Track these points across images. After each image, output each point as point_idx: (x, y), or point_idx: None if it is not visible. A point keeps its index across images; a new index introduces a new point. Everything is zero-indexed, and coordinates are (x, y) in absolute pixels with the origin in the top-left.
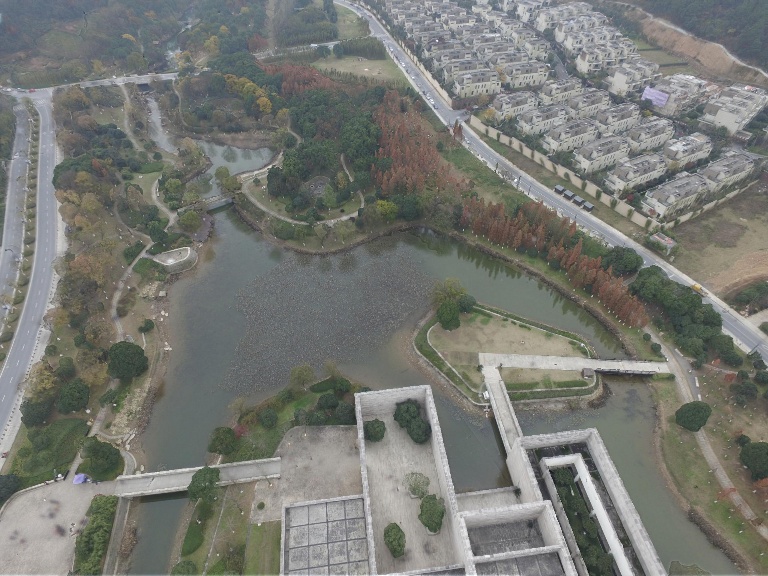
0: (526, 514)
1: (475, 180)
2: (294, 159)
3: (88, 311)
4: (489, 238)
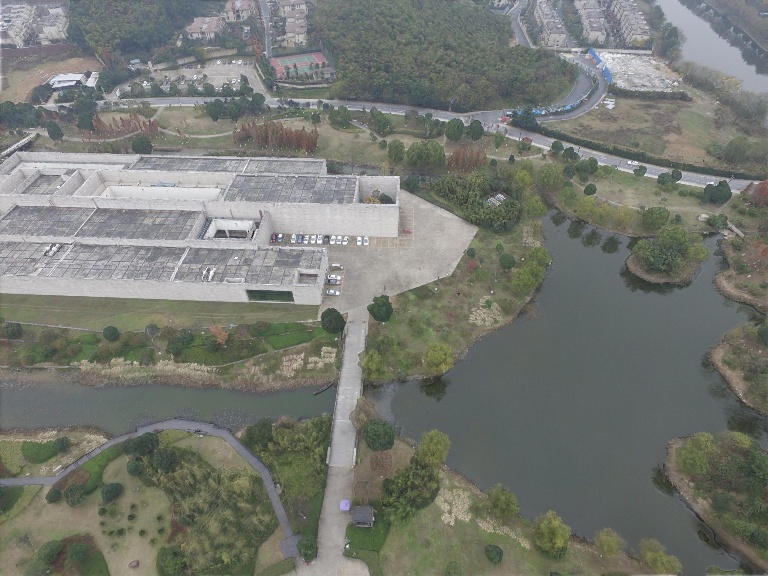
0: (21, 182)
1: None
2: None
3: None
4: None
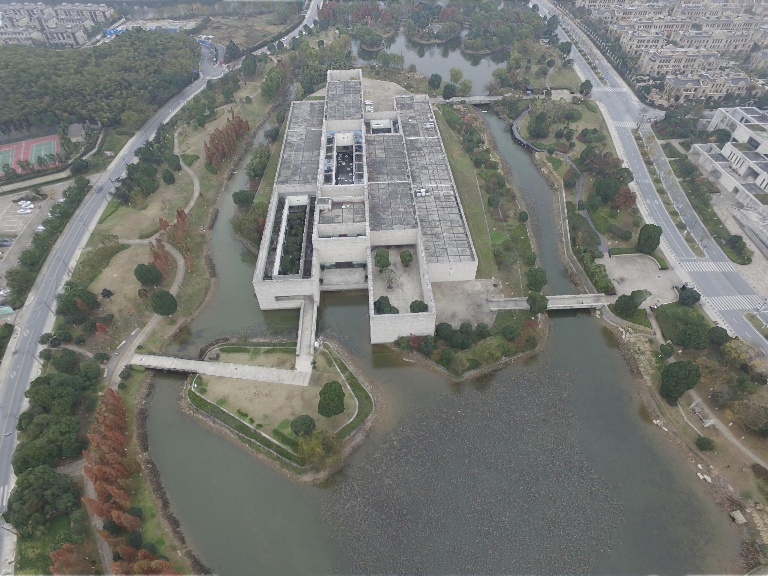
0: None
1: None
2: None
3: None
4: None
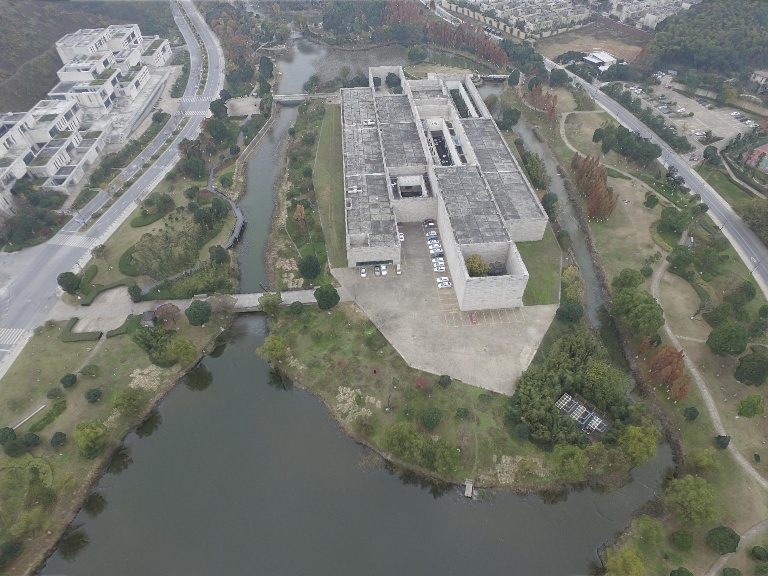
0: None
1: None
2: (338, 8)
3: (243, 57)
4: (441, 42)
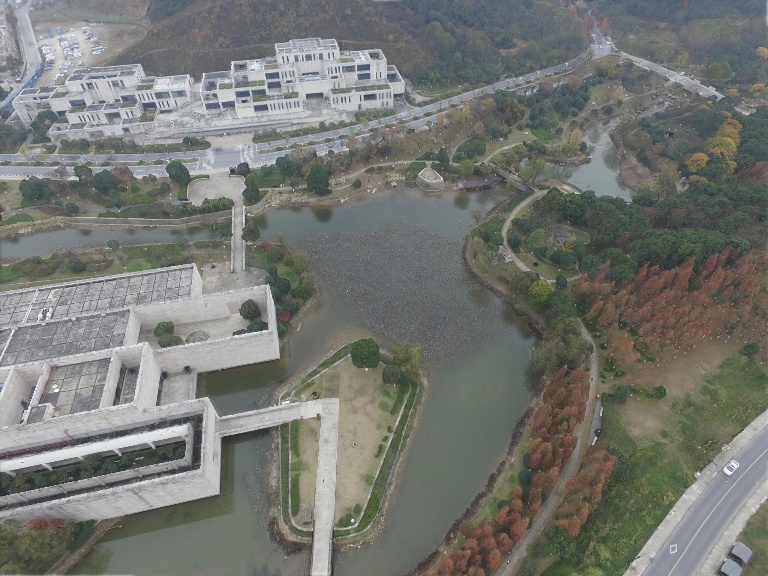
0: None
1: (685, 403)
2: (576, 196)
3: None
4: None
